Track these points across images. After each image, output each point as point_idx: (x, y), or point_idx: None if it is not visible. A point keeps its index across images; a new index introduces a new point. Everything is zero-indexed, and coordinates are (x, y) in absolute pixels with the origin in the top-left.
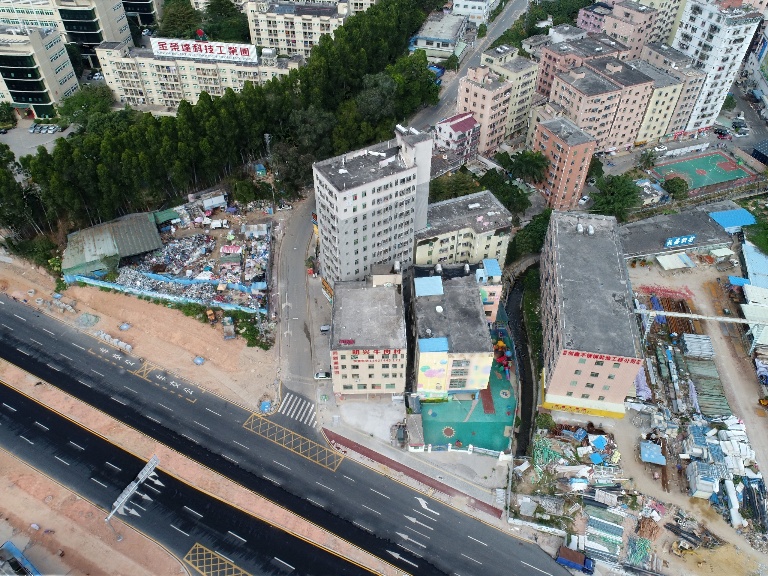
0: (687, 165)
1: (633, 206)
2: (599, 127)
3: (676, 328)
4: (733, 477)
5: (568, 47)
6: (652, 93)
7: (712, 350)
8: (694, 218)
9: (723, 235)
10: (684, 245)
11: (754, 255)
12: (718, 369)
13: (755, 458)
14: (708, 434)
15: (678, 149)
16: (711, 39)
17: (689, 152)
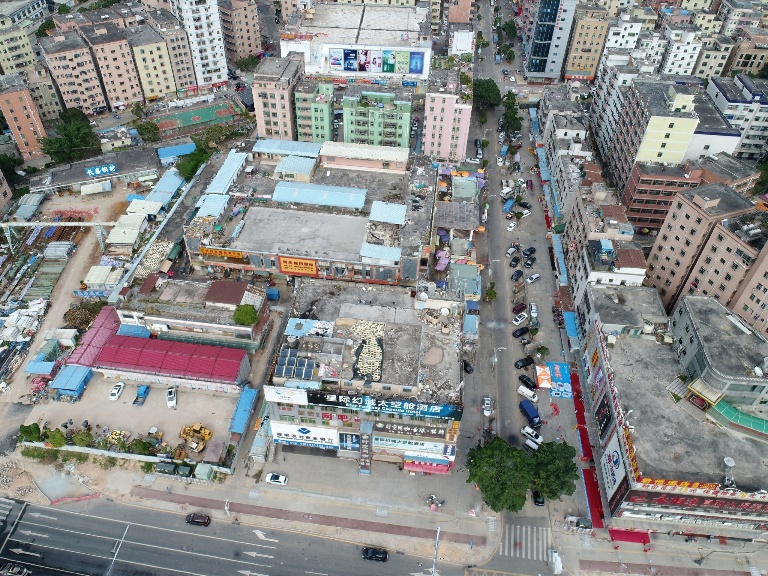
0: (188, 114)
1: (82, 146)
2: (83, 83)
3: (55, 239)
4: (2, 343)
5: (79, 16)
6: (133, 51)
7: (64, 251)
8: (140, 153)
9: (154, 164)
10: (109, 174)
11: (169, 178)
12: (67, 266)
13: (40, 328)
14: (11, 314)
15: (180, 101)
16: (179, 2)
17: (196, 103)
